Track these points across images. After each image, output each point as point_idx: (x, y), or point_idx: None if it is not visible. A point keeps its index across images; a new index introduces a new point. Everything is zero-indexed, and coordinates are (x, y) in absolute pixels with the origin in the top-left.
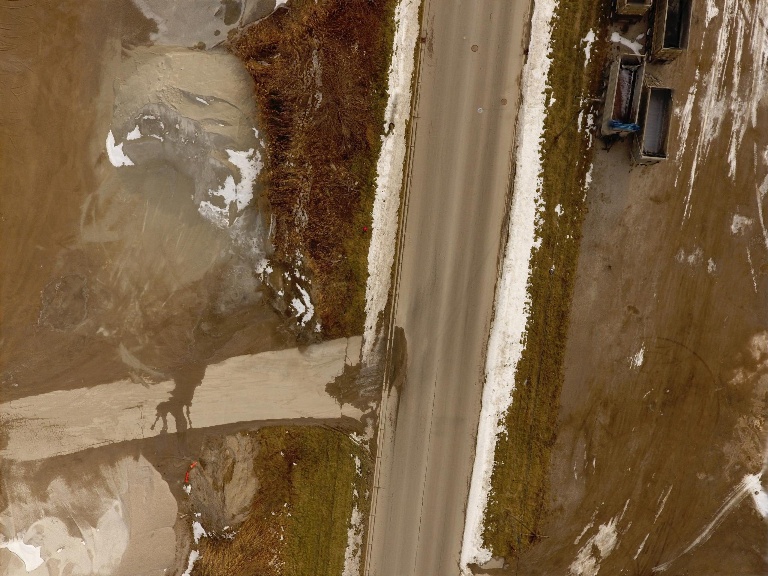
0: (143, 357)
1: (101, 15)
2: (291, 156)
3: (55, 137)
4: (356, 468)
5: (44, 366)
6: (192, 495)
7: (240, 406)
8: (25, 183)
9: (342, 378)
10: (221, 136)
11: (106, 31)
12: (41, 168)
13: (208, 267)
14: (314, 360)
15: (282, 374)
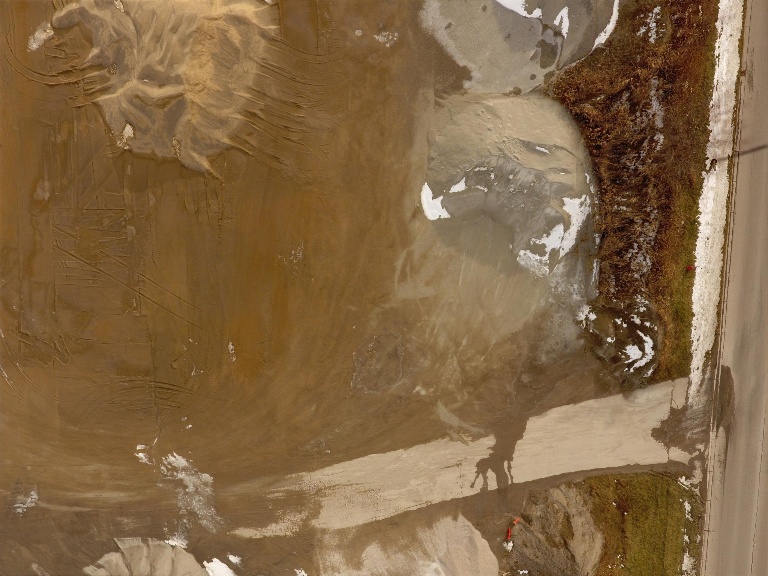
0: (462, 414)
1: (412, 65)
2: (620, 199)
3: (367, 193)
4: (686, 513)
5: (358, 430)
6: (515, 552)
7: (563, 457)
8: (336, 242)
9: (668, 422)
10: (563, 185)
11: (418, 81)
12: (353, 226)
13: (527, 317)
14: (639, 405)
15: (606, 422)
